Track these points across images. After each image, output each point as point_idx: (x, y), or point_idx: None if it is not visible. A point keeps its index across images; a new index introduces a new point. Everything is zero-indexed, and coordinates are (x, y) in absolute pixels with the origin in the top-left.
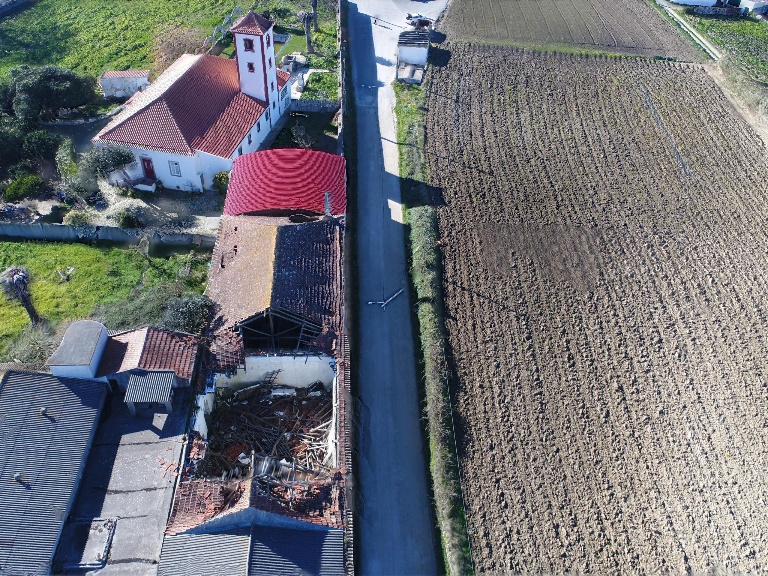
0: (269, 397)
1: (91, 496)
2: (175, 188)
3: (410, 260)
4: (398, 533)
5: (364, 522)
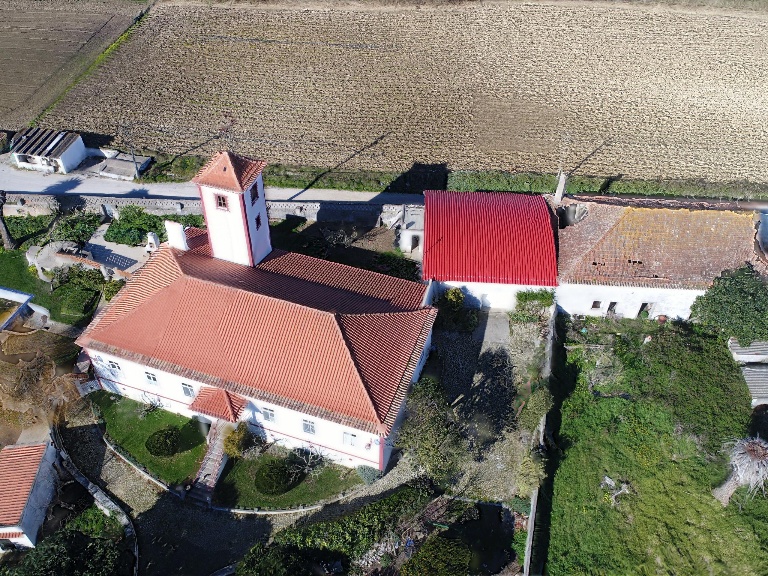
0: None
1: None
2: (418, 379)
3: (538, 195)
4: None
5: None
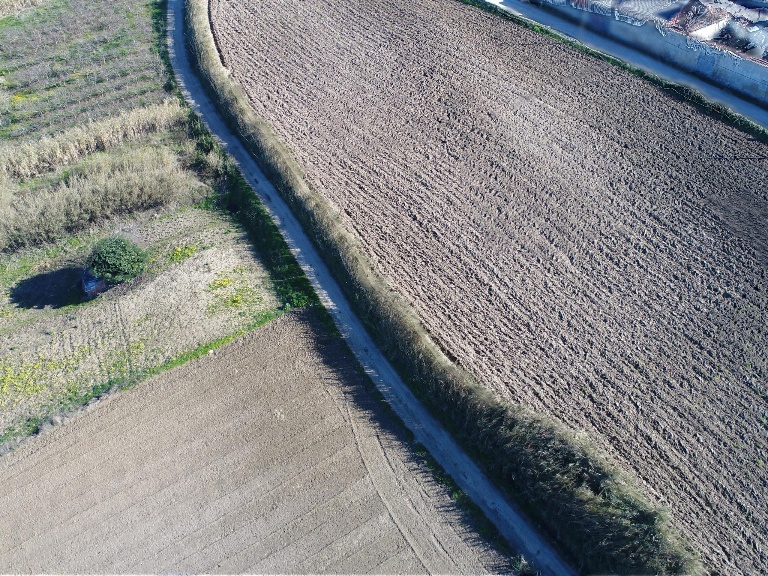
0: (752, 41)
1: (748, 4)
2: None
3: None
4: (651, 66)
5: (664, 49)
